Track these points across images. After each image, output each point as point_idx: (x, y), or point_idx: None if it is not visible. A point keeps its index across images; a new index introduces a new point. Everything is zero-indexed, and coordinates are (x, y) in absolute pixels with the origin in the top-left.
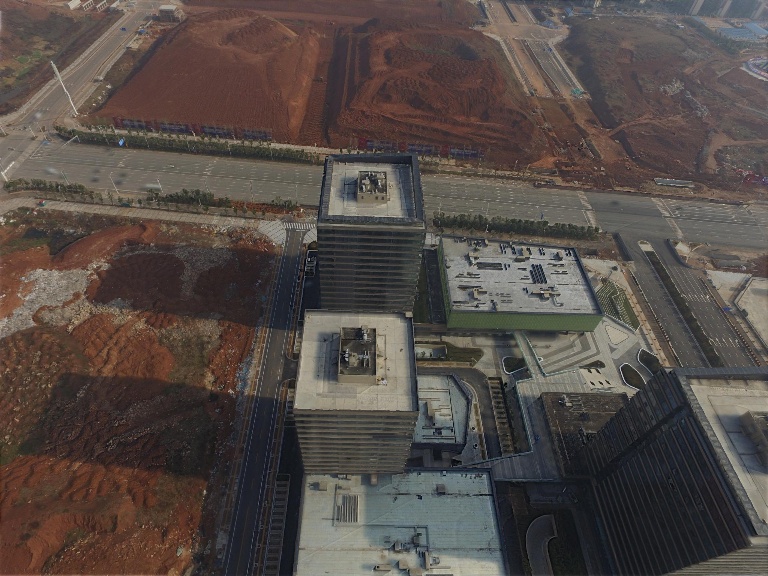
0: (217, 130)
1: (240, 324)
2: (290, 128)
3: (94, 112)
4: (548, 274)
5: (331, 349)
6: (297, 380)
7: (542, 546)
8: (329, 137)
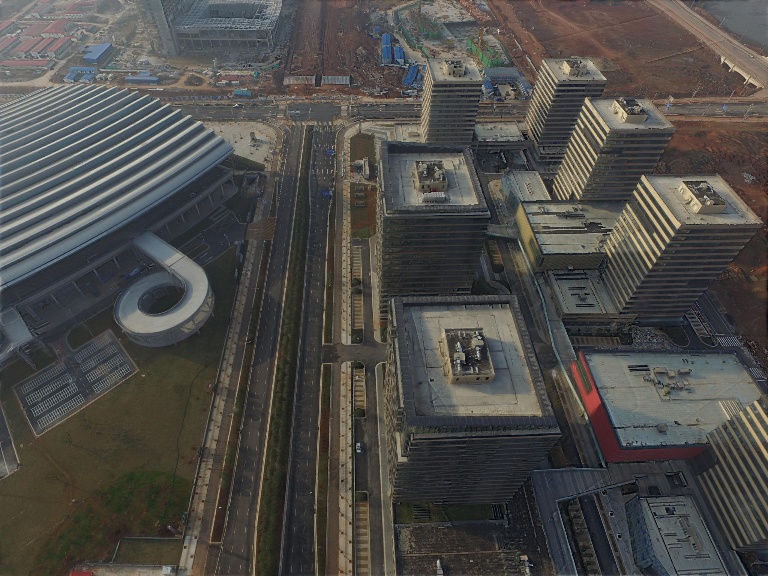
0: None
1: None
2: None
3: None
4: None
5: None
6: None
7: None
8: None
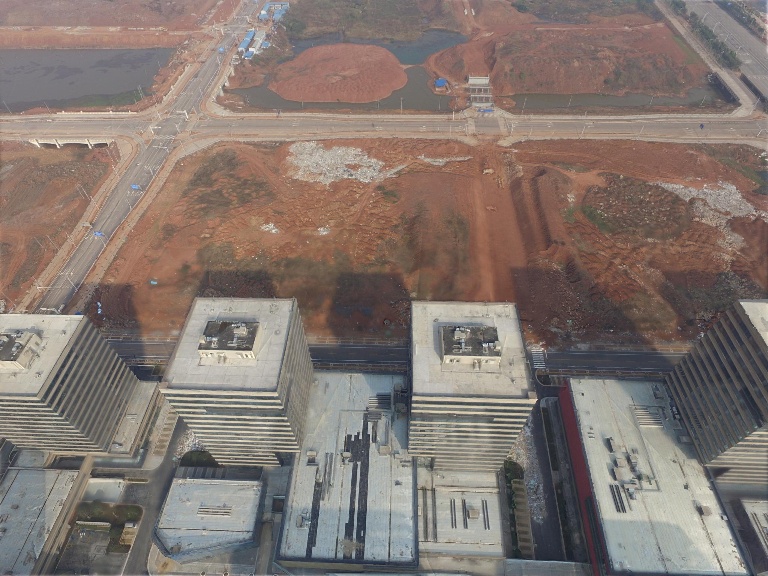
0: None
1: None
2: None
3: None
4: None
5: None
6: (767, 301)
7: None
8: None
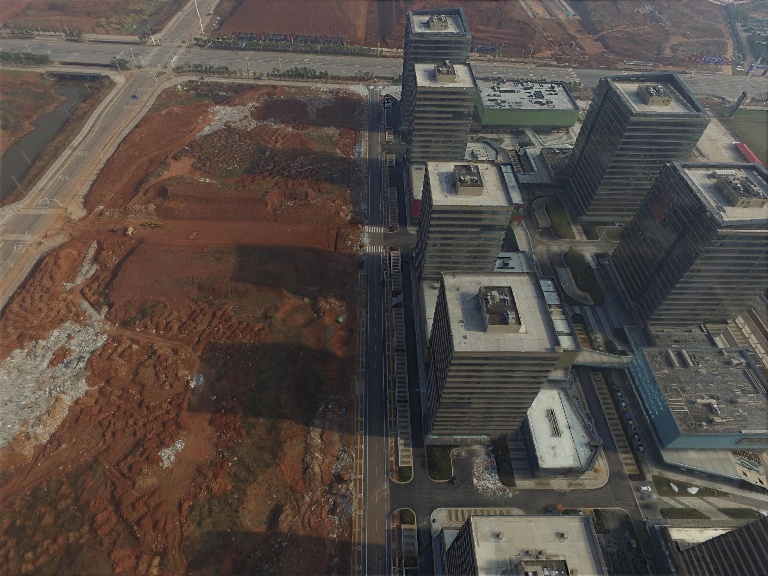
0: (307, 38)
1: (350, 129)
2: (358, 37)
3: (214, 32)
4: (545, 95)
5: (430, 73)
6: None
7: (542, 210)
8: (387, 42)
